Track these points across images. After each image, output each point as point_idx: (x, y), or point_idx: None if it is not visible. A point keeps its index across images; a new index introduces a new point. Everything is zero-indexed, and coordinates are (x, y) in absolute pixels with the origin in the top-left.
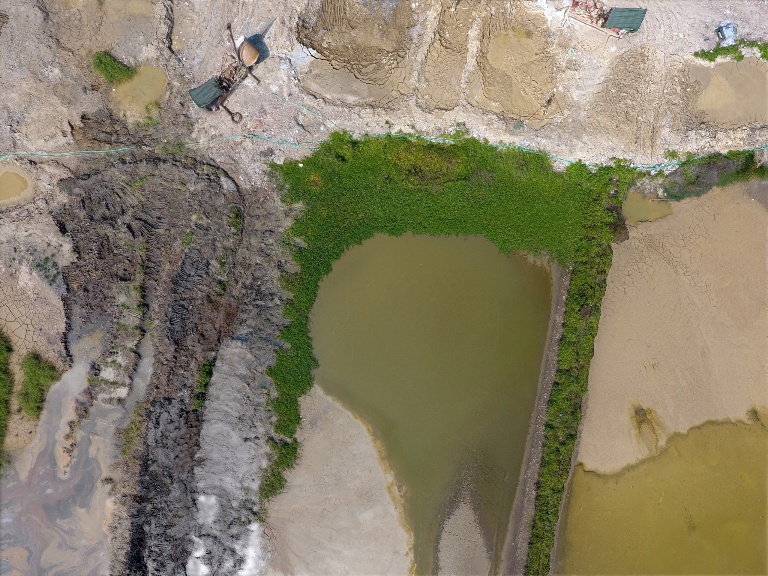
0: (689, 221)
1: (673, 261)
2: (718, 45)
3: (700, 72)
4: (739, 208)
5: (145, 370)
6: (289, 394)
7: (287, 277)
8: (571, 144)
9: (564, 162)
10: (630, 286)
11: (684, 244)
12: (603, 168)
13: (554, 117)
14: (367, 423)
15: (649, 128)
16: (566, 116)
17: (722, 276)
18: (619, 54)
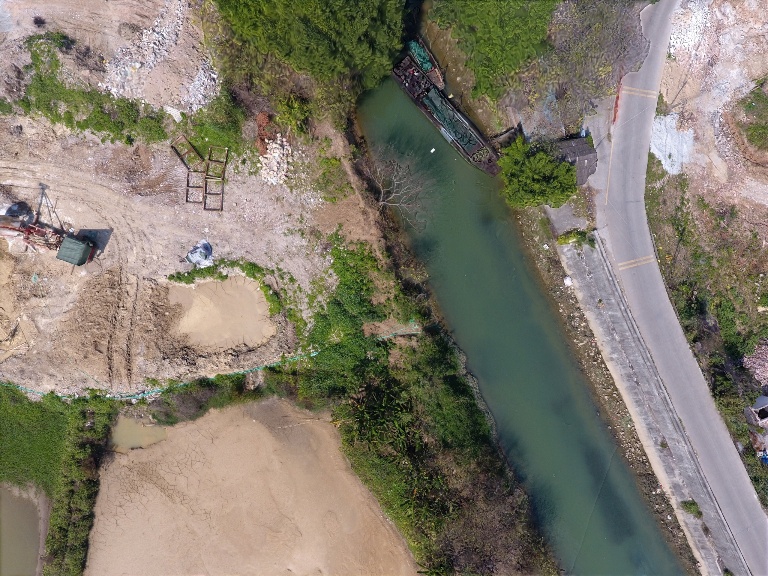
0: (185, 446)
1: (168, 489)
2: (194, 267)
3: (181, 294)
4: (239, 430)
5: None
6: None
7: None
8: (36, 377)
9: (36, 393)
10: (122, 517)
11: (180, 471)
12: (73, 401)
13: (18, 348)
14: None
15: (122, 357)
16: (31, 347)
17: (223, 502)
18: (89, 279)
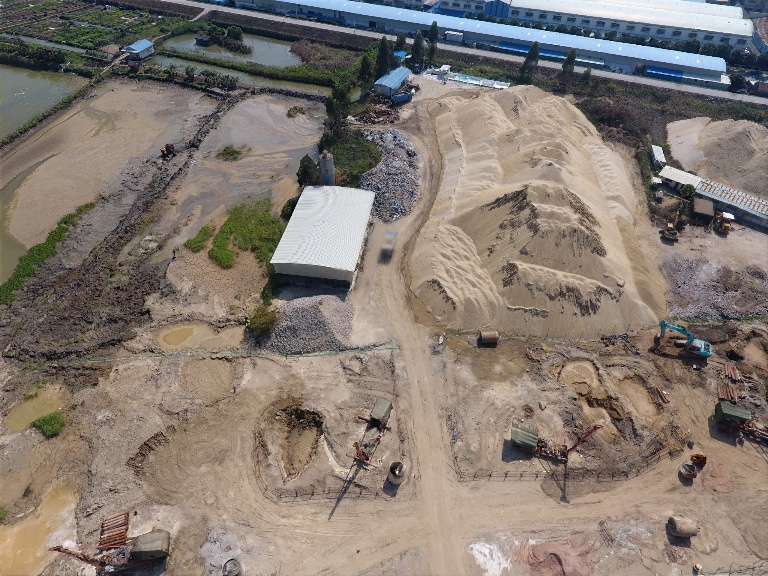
0: None
1: None
2: None
3: None
4: None
5: (129, 247)
6: (49, 244)
7: (8, 301)
8: None
9: None
10: None
11: None
12: None
13: None
14: (7, 233)
15: None
16: None
17: None
18: None
